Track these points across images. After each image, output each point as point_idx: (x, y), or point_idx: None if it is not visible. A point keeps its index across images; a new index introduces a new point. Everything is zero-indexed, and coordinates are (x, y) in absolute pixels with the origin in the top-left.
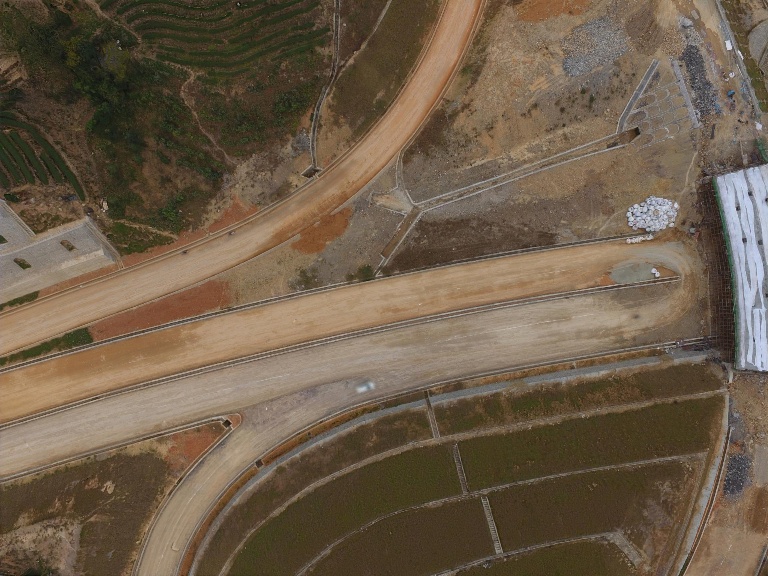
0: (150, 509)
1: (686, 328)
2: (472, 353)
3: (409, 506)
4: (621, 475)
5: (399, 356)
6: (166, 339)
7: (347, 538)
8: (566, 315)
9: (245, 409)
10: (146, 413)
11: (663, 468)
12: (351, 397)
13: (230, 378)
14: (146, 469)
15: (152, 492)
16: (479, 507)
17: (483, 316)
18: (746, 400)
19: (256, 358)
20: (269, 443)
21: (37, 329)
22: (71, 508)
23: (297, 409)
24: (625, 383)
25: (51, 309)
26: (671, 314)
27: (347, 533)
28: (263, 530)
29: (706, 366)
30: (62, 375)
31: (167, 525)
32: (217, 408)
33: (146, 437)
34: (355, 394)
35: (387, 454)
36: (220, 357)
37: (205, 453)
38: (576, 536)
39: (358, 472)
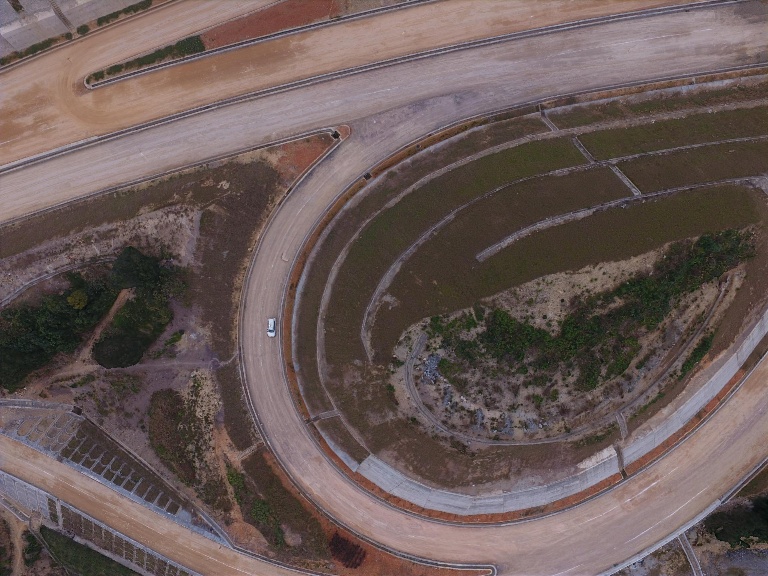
0: (261, 217)
1: None
2: (585, 68)
3: (534, 174)
4: (760, 144)
5: (509, 70)
6: (275, 50)
7: (471, 203)
8: (686, 29)
9: (353, 122)
10: (256, 124)
11: None
12: (460, 112)
13: (338, 90)
14: (258, 174)
15: (263, 199)
16: (609, 171)
17: (597, 30)
18: None
19: (365, 69)
20: (377, 157)
21: (151, 38)
22: (190, 197)
23: (405, 123)
24: (752, 90)
25: (164, 18)
26: None
27: (471, 199)
28: (379, 219)
29: None
30: (175, 85)
31: (277, 235)
32: (326, 121)
33: (256, 147)
34: (464, 109)
35: (504, 146)
36: (329, 69)
37: (314, 164)
38: (719, 179)
39: (475, 162)
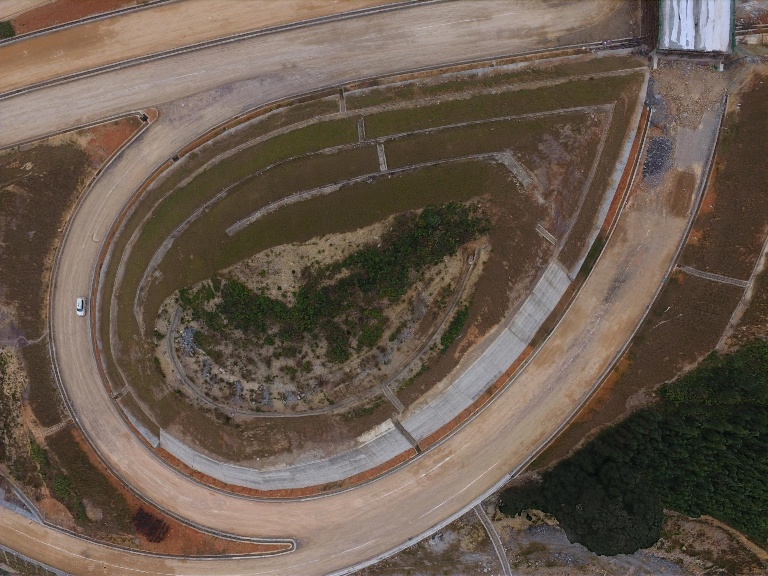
0: (71, 199)
1: (614, 29)
2: (389, 52)
3: (304, 152)
4: (521, 122)
5: (314, 54)
6: (85, 35)
7: (242, 181)
8: (487, 14)
9: (162, 105)
10: (67, 108)
11: (566, 116)
12: (266, 95)
13: (147, 74)
14: (65, 156)
15: (72, 181)
16: (373, 149)
17: (400, 14)
18: (669, 81)
19: (172, 53)
20: (185, 139)
21: None
22: None
23: (213, 106)
24: (543, 72)
25: None
26: (599, 14)
27: (242, 177)
28: (170, 198)
29: (631, 57)
30: None
31: (88, 216)
32: (135, 104)
33: (67, 130)
34: (270, 92)
35: (293, 127)
36: (137, 53)
37: (123, 146)
38: (463, 155)
39: (263, 143)
